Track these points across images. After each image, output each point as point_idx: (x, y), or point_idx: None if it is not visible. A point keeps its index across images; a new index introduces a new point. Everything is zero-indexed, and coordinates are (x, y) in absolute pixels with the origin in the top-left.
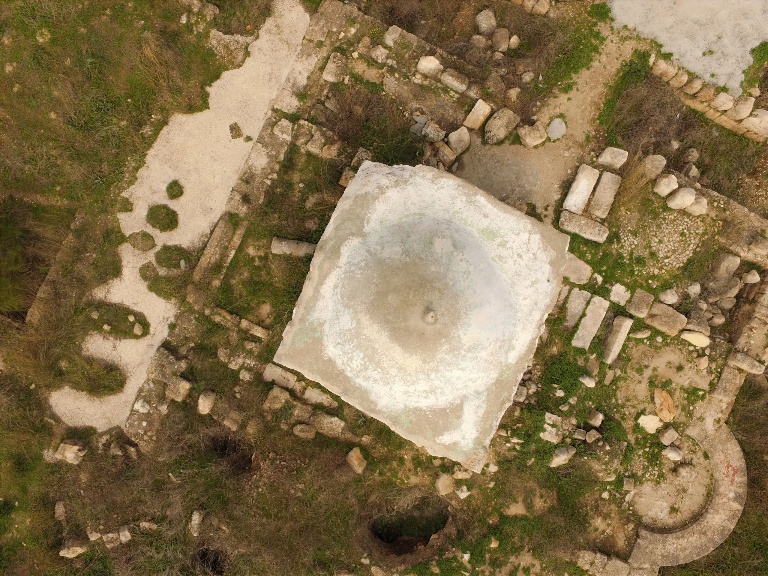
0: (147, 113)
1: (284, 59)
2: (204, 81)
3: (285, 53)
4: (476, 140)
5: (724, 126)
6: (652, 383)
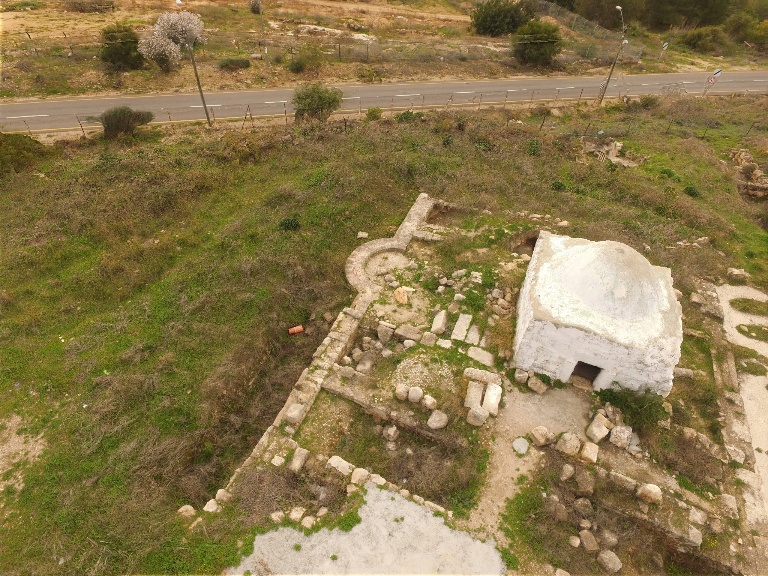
0: None
1: None
2: None
3: None
4: (582, 437)
5: None
6: (410, 305)
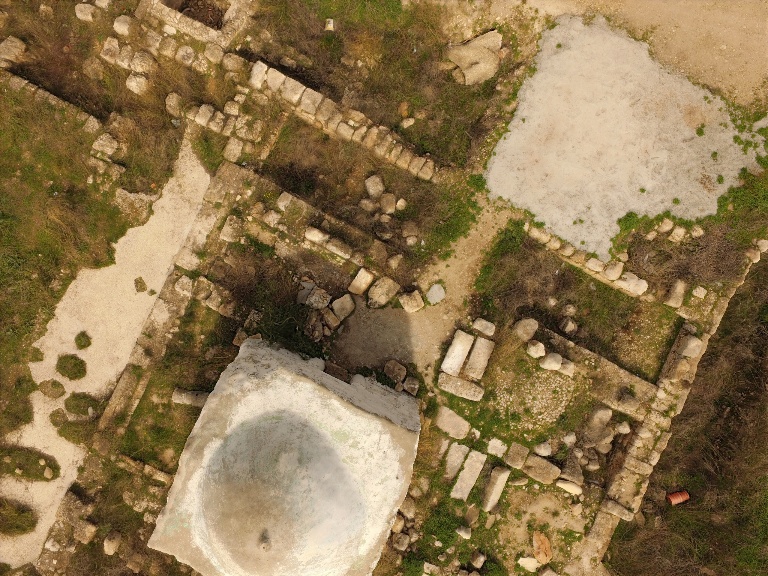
0: (56, 268)
1: (186, 217)
2: (110, 238)
3: (187, 211)
4: (361, 303)
5: (601, 281)
6: (530, 527)
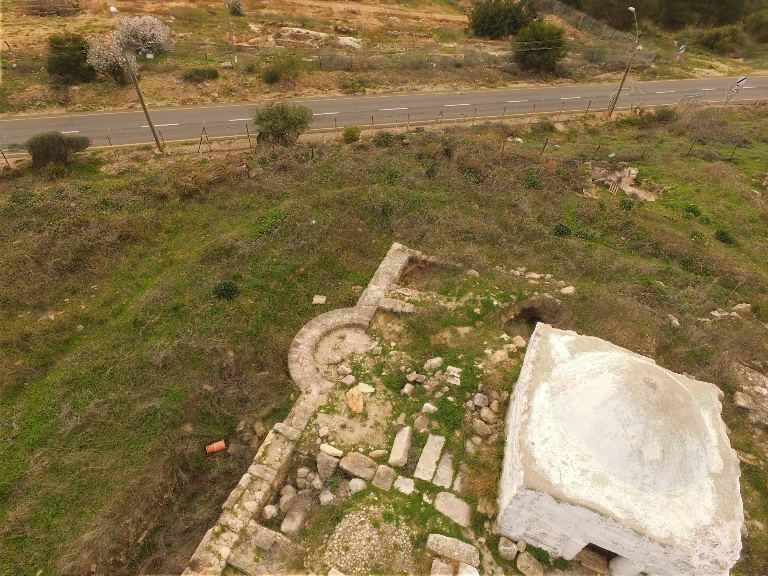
0: None
1: None
2: None
3: None
4: None
5: None
6: (366, 415)
